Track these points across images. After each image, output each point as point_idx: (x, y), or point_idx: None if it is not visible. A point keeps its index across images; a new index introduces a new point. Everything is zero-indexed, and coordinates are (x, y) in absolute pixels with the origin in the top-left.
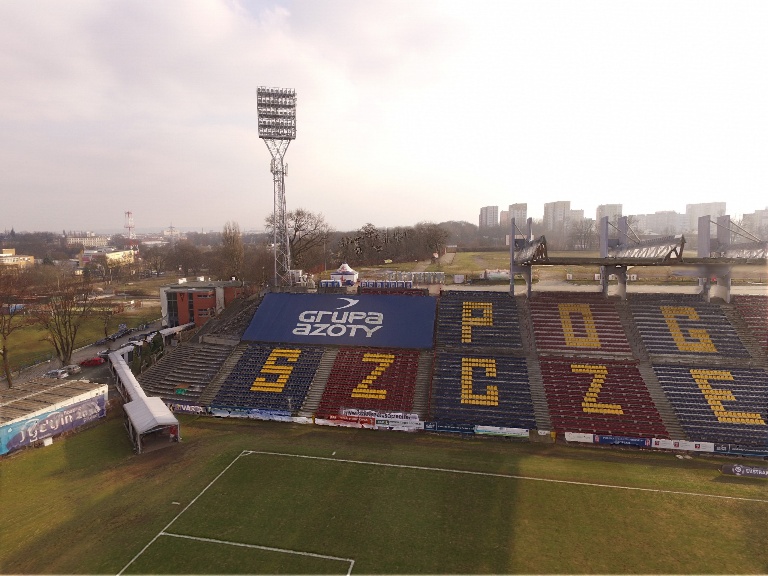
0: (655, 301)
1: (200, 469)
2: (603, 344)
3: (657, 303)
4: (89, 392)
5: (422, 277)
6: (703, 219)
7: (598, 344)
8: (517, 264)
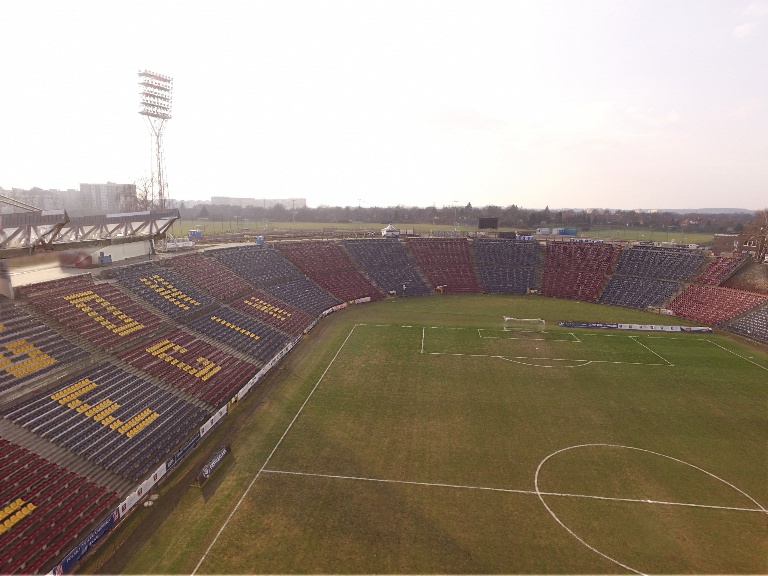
0: None
1: None
2: None
3: None
4: None
5: None
6: None
7: None
8: None
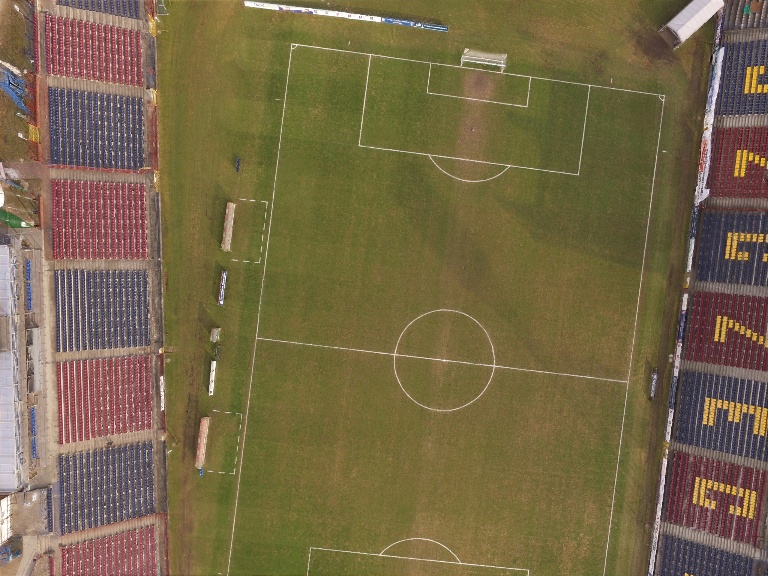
0: None
1: (643, 78)
2: None
3: None
4: None
5: None
6: None
7: None
8: None
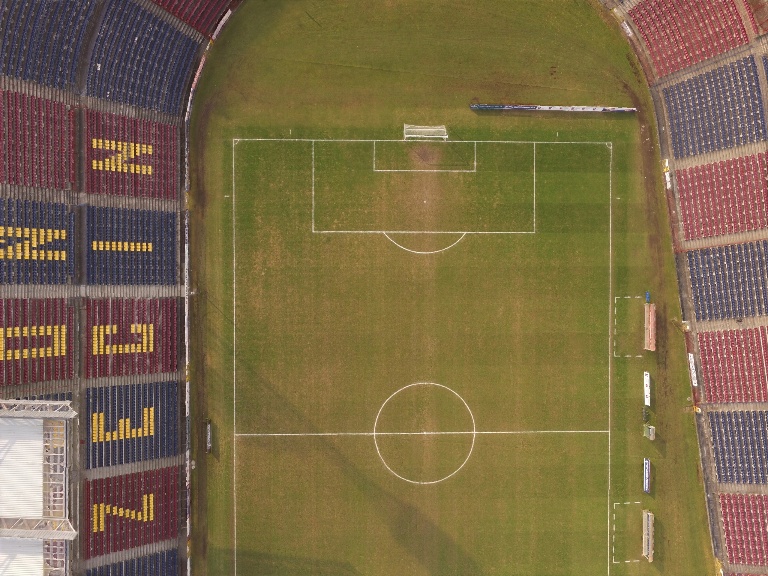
0: None
1: None
2: None
3: None
4: None
5: None
6: None
7: None
8: None
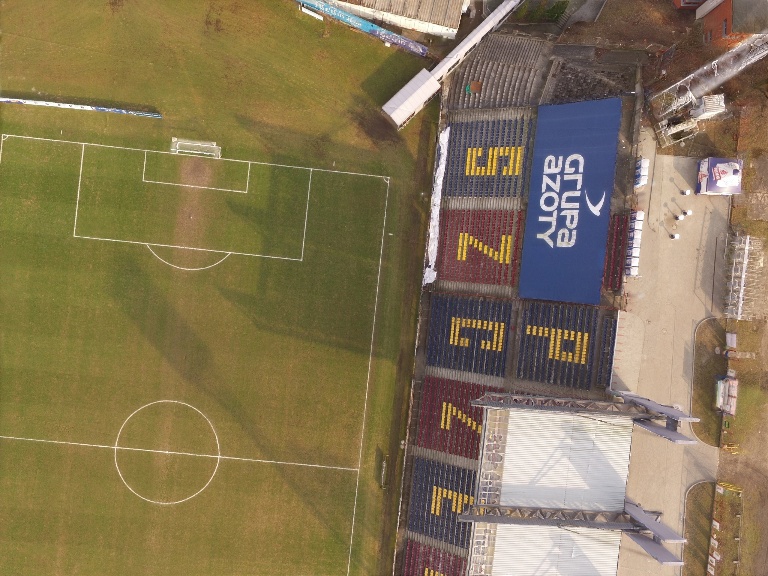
0: None
1: (366, 160)
2: None
3: None
4: (442, 26)
5: None
6: None
7: None
8: None
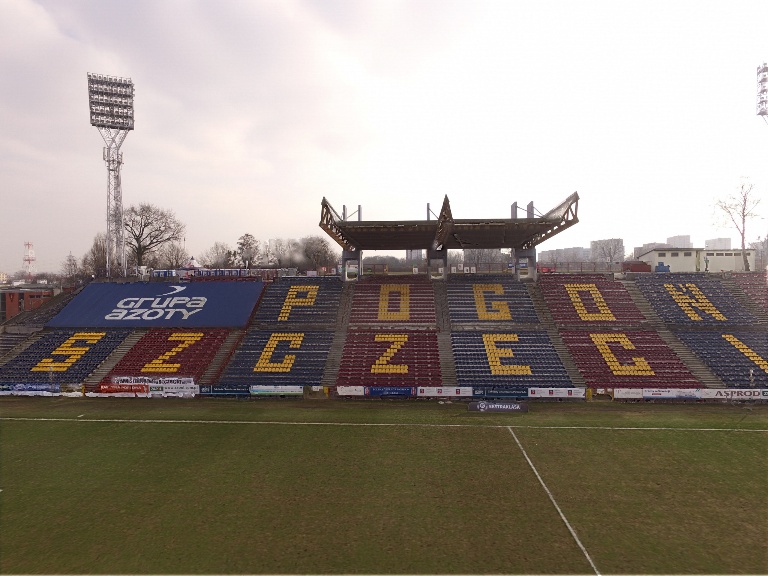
0: (470, 280)
1: None
2: (412, 317)
3: (471, 282)
4: None
5: (275, 274)
6: (513, 206)
7: (407, 317)
8: (347, 249)
